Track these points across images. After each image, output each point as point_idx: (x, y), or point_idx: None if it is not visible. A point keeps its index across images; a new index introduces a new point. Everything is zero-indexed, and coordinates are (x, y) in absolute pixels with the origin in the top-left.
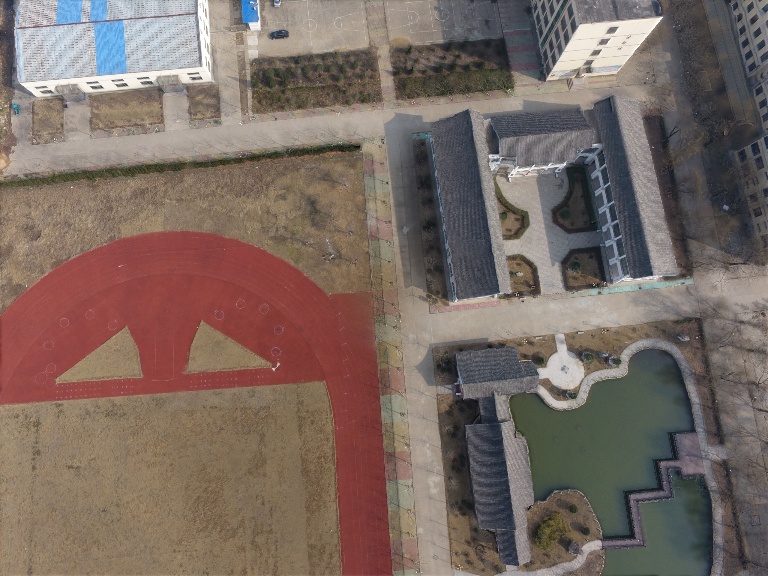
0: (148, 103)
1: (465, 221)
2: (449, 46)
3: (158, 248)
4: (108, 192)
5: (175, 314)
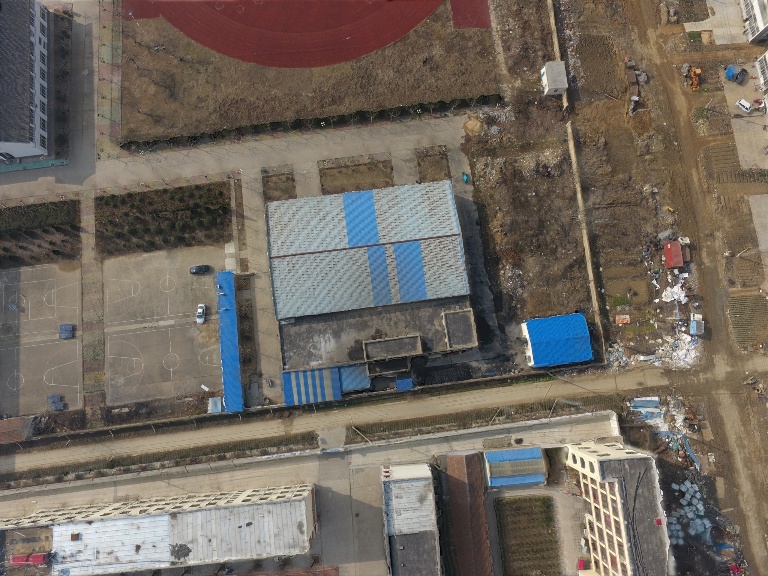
0: (336, 190)
1: (6, 42)
2: (13, 259)
3: (316, 54)
4: (367, 102)
5: (297, 1)
